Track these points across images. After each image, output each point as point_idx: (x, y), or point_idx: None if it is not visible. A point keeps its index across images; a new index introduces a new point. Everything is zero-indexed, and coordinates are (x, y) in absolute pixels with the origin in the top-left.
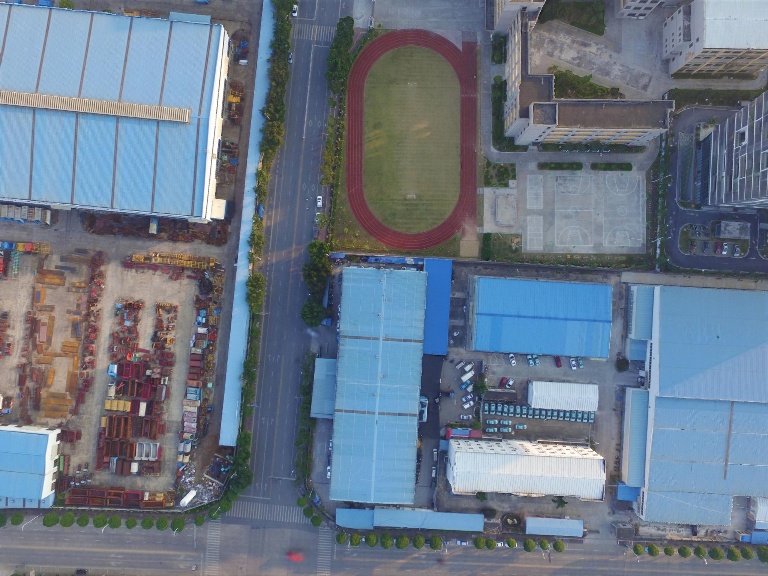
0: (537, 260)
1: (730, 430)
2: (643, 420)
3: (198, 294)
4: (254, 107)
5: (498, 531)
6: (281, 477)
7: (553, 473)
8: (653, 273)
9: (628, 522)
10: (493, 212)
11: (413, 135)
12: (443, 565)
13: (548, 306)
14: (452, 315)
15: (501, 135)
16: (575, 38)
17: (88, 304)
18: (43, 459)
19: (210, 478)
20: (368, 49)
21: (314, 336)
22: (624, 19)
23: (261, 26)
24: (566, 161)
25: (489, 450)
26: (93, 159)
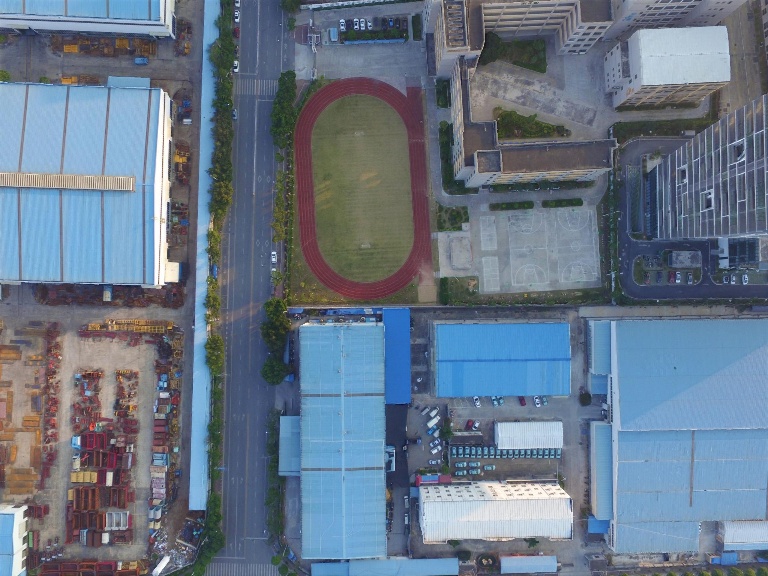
0: (495, 301)
1: (692, 458)
2: (608, 454)
3: (158, 359)
4: (201, 168)
5: (473, 573)
6: (253, 537)
7: (521, 516)
8: (610, 306)
9: (601, 553)
10: (448, 256)
11: (364, 184)
12: None
13: (507, 348)
14: (414, 361)
15: (451, 179)
16: (518, 77)
17: (46, 377)
18: (10, 539)
19: (183, 543)
20: (313, 100)
21: (278, 392)
22: (565, 55)
23: (202, 85)
24: (517, 200)
25: (457, 497)
26: (39, 234)
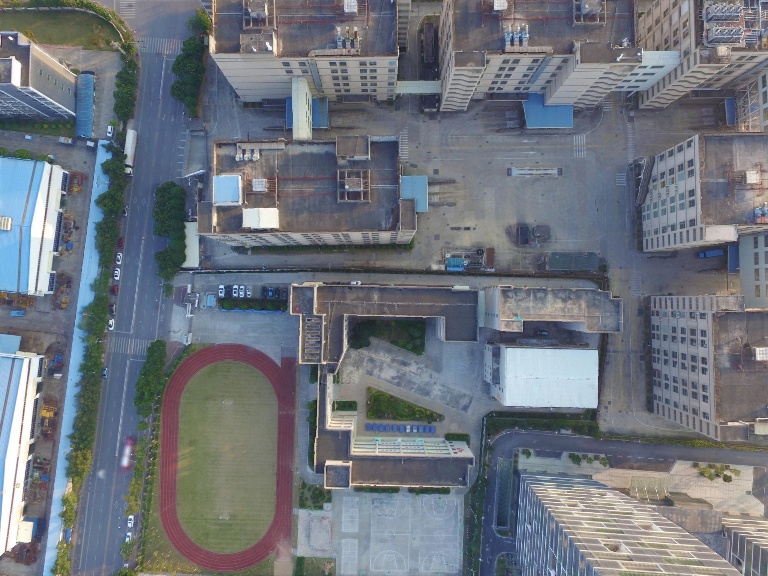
0: None
1: None
2: None
3: None
4: (63, 430)
5: None
6: None
7: None
8: None
9: None
10: (307, 535)
11: (229, 453)
12: None
13: None
14: None
15: None
16: (395, 357)
17: None
18: None
19: None
20: (185, 364)
21: None
22: None
23: (72, 347)
24: None
25: None
26: None
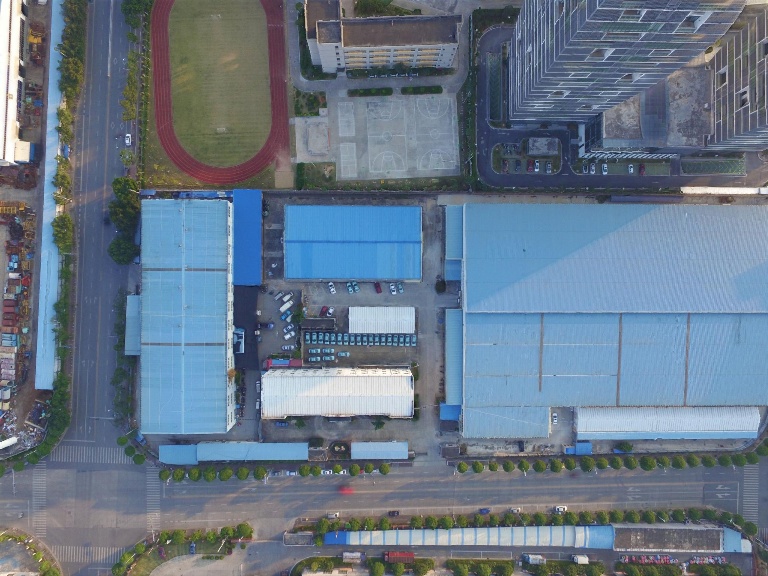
0: (351, 187)
1: (542, 342)
2: (458, 338)
3: (9, 240)
4: (52, 46)
5: (323, 458)
6: (99, 417)
7: (361, 392)
8: (468, 194)
9: (456, 442)
10: (305, 142)
11: (221, 68)
12: (274, 497)
13: (357, 230)
14: (269, 247)
15: (309, 63)
16: None
17: None
18: None
19: (31, 424)
20: None
21: (131, 276)
22: None
23: None
24: (376, 87)
25: (298, 374)
26: None
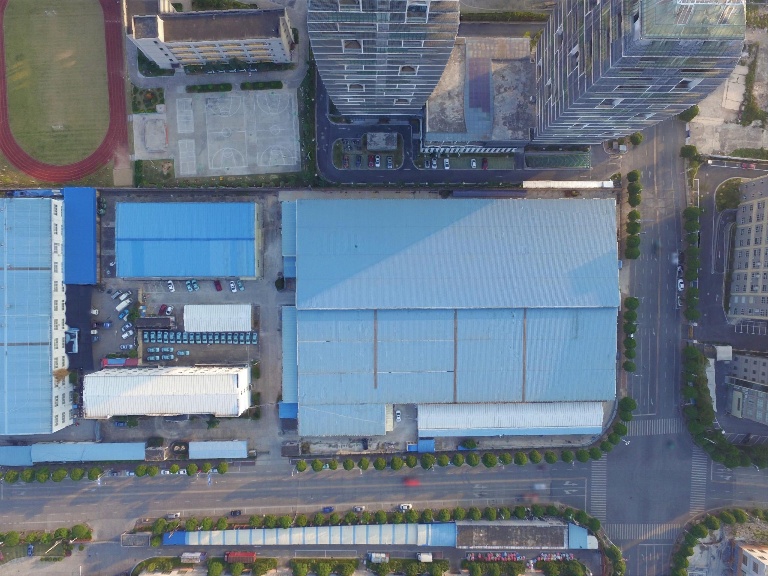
0: (190, 184)
1: (376, 339)
2: (294, 336)
3: None
4: None
5: (161, 458)
6: None
7: (185, 391)
8: (308, 190)
9: (299, 441)
10: (143, 139)
11: (57, 65)
12: (114, 497)
13: (190, 227)
14: (107, 245)
15: (145, 60)
16: None
17: None
18: None
19: None
20: None
21: None
22: None
23: None
24: (215, 83)
25: (123, 373)
26: None
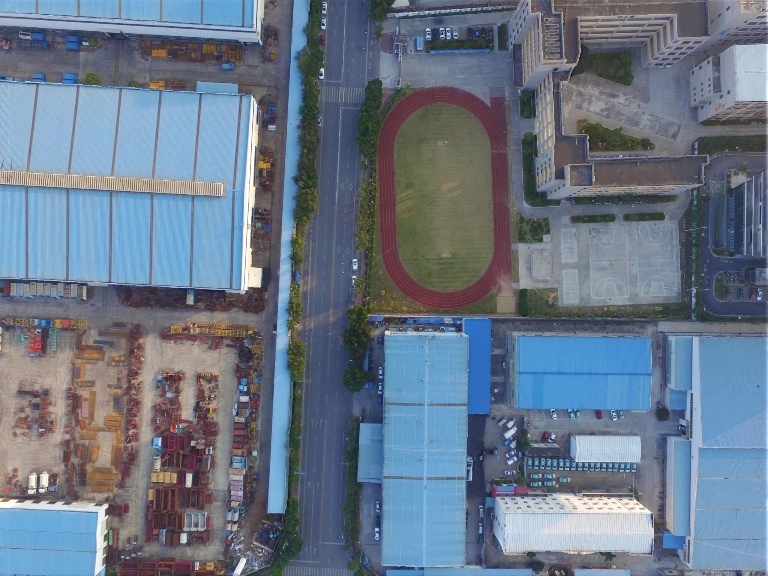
0: (574, 314)
1: None
2: (686, 470)
3: (238, 362)
4: (286, 174)
5: None
6: (331, 542)
7: (602, 530)
8: (689, 321)
9: (673, 568)
10: (528, 267)
11: (445, 194)
12: None
13: (588, 362)
14: (492, 372)
15: (533, 190)
16: (603, 89)
17: (129, 378)
18: (94, 537)
19: (259, 545)
20: (396, 109)
21: (356, 399)
22: (651, 68)
23: (289, 92)
24: (599, 213)
25: (538, 509)
26: (129, 237)
